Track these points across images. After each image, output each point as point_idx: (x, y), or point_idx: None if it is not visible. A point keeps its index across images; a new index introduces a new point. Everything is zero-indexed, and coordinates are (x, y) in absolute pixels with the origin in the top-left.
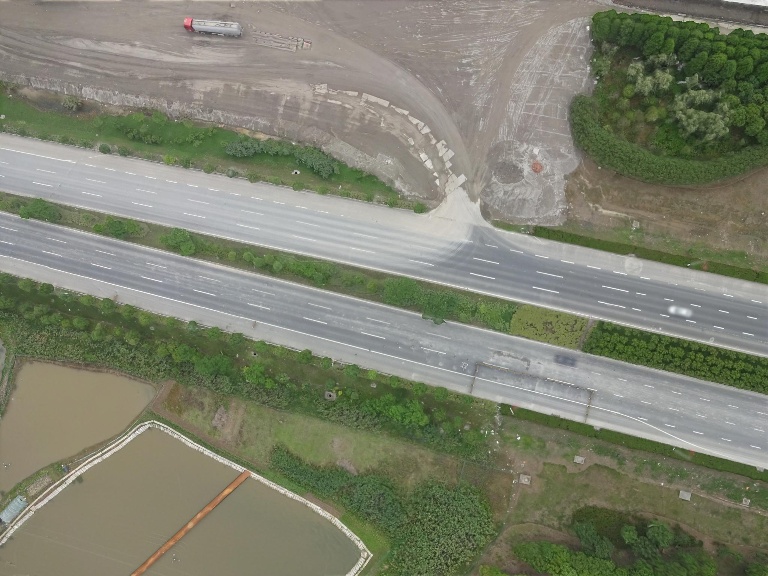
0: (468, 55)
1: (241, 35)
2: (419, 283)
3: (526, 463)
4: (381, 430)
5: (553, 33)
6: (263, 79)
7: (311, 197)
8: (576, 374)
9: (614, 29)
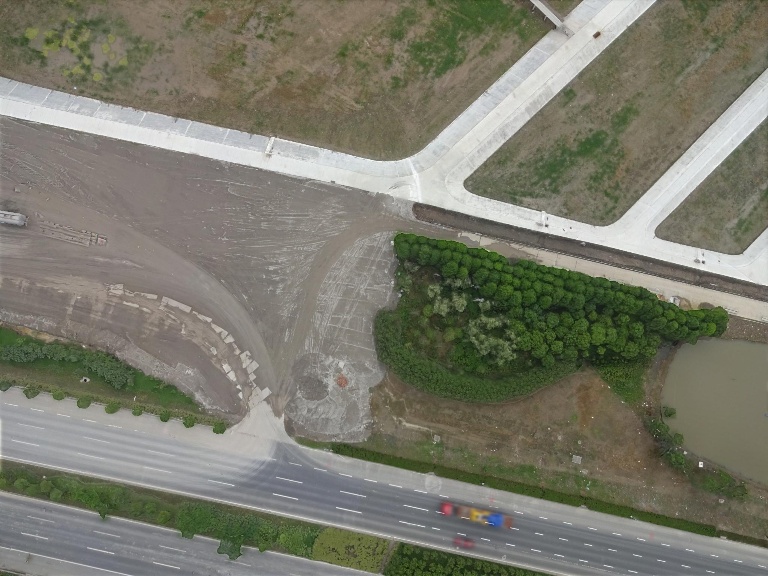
0: (275, 262)
1: (25, 225)
2: (218, 506)
3: None
4: None
5: (359, 245)
6: (50, 275)
7: (101, 409)
8: None
9: (414, 253)
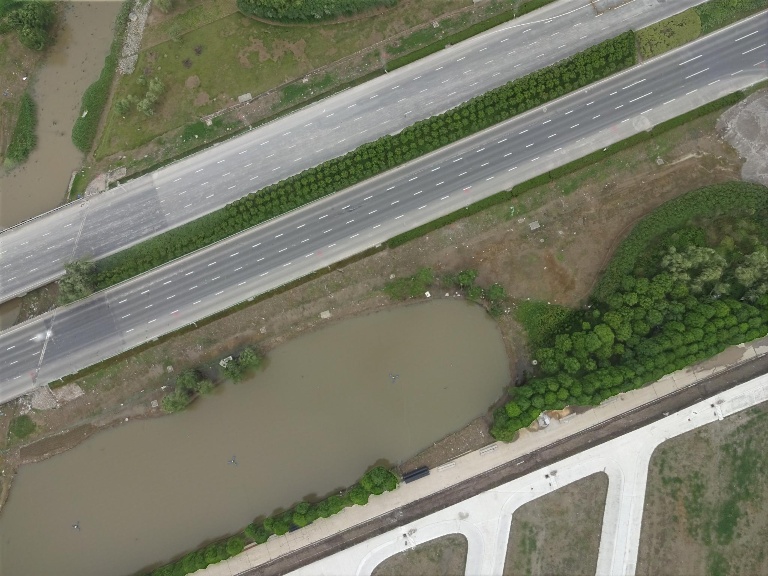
0: None
1: None
2: None
3: None
4: None
5: None
6: None
7: None
8: (619, 17)
9: None
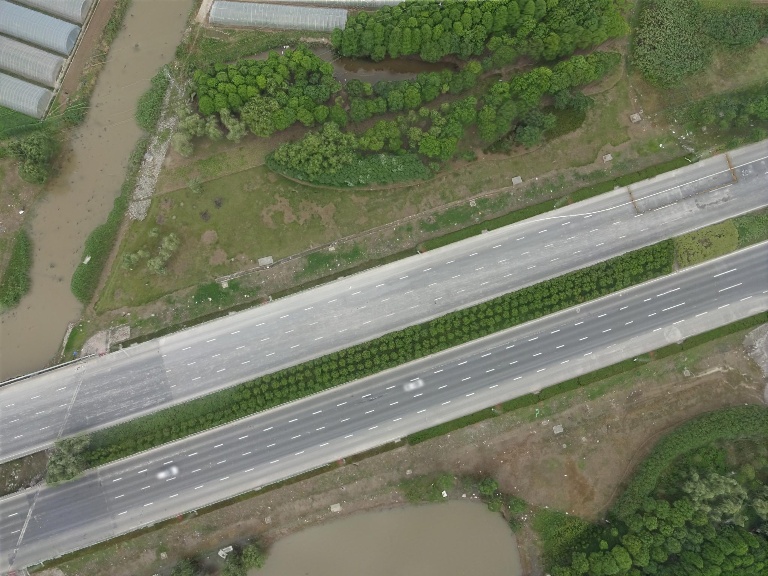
0: None
1: None
2: None
3: (643, 130)
4: (766, 85)
5: None
6: None
7: None
8: (659, 220)
9: None
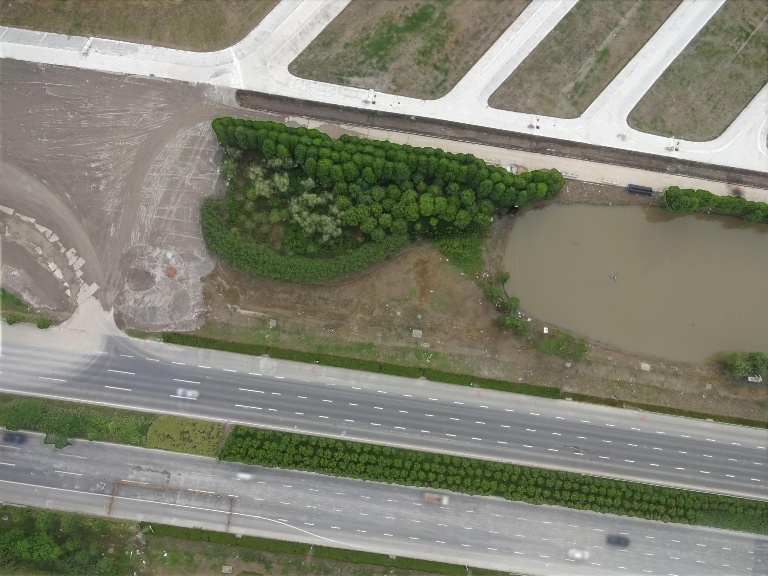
0: (97, 159)
1: None
2: (50, 402)
3: None
4: (17, 565)
5: (182, 136)
6: None
7: None
8: (216, 482)
9: (231, 135)
